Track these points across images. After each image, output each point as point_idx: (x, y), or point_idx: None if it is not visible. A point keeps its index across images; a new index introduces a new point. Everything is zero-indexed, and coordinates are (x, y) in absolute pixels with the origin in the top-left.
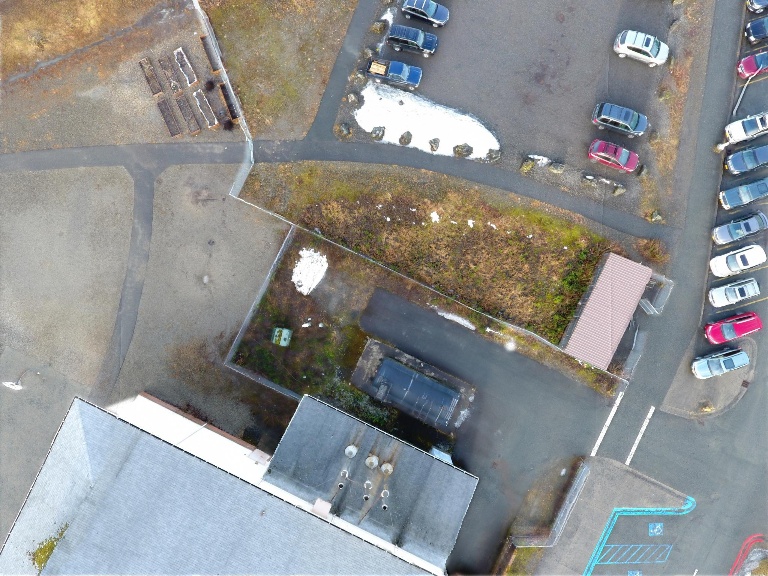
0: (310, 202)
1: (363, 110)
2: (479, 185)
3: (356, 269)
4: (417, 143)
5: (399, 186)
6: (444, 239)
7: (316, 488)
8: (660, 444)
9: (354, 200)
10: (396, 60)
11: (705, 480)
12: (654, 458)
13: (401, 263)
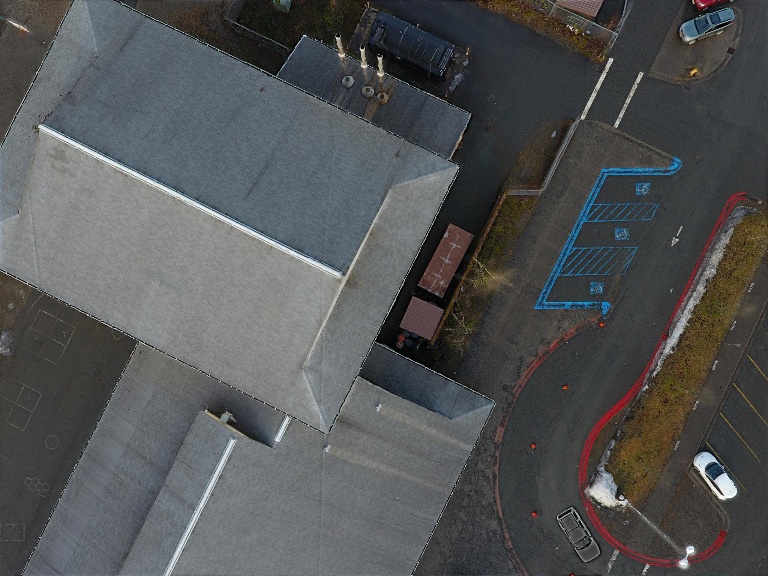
0: None
1: None
2: None
3: None
4: None
5: None
6: None
7: None
8: (648, 108)
9: None
10: None
11: (691, 142)
12: (642, 121)
13: None
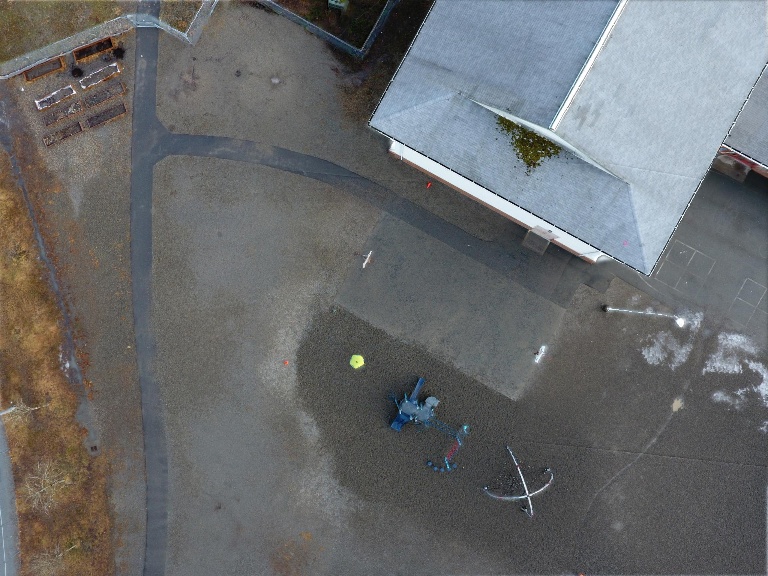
0: None
1: None
2: None
3: None
4: None
5: None
6: None
7: None
8: None
9: None
10: None
11: None
12: None
13: None
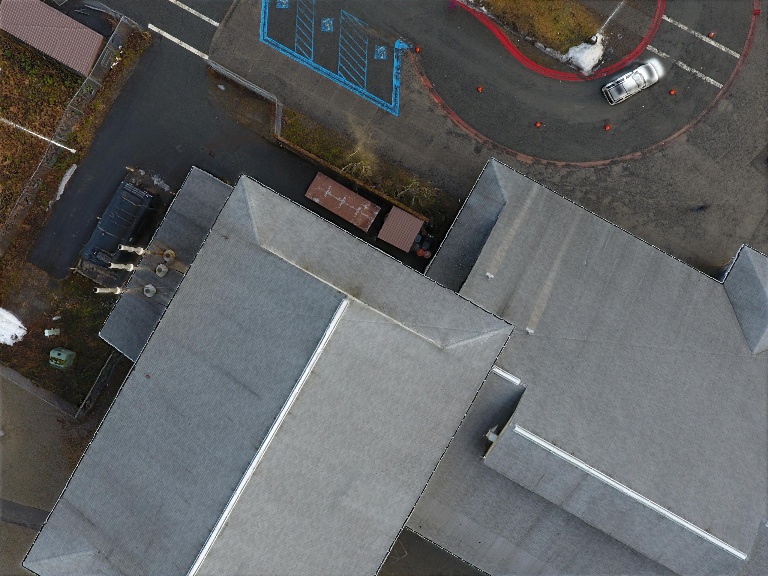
0: None
1: None
2: None
3: (7, 279)
4: None
5: None
6: None
7: None
8: None
9: None
10: None
11: None
12: None
13: (3, 234)
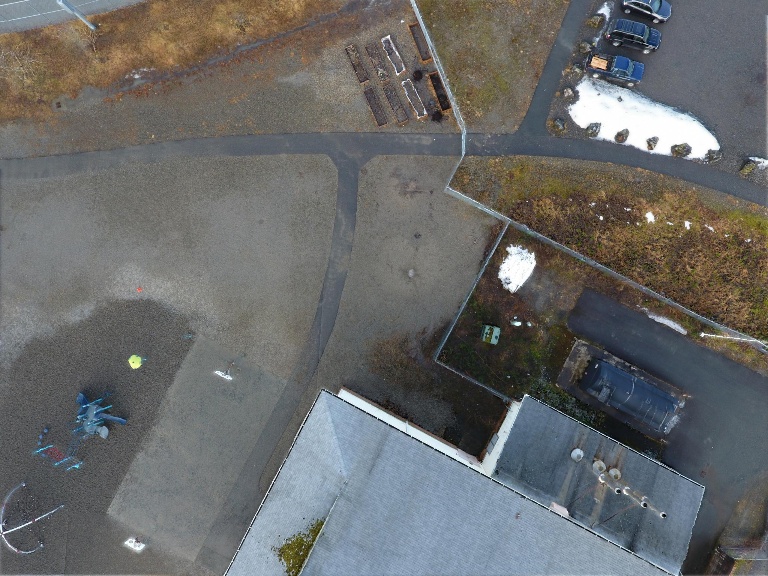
0: (520, 198)
1: (579, 105)
2: (697, 186)
3: (565, 268)
4: (635, 141)
5: (613, 184)
6: (660, 240)
7: (544, 491)
8: None
9: (566, 197)
10: (620, 55)
11: None
12: None
13: (612, 263)
